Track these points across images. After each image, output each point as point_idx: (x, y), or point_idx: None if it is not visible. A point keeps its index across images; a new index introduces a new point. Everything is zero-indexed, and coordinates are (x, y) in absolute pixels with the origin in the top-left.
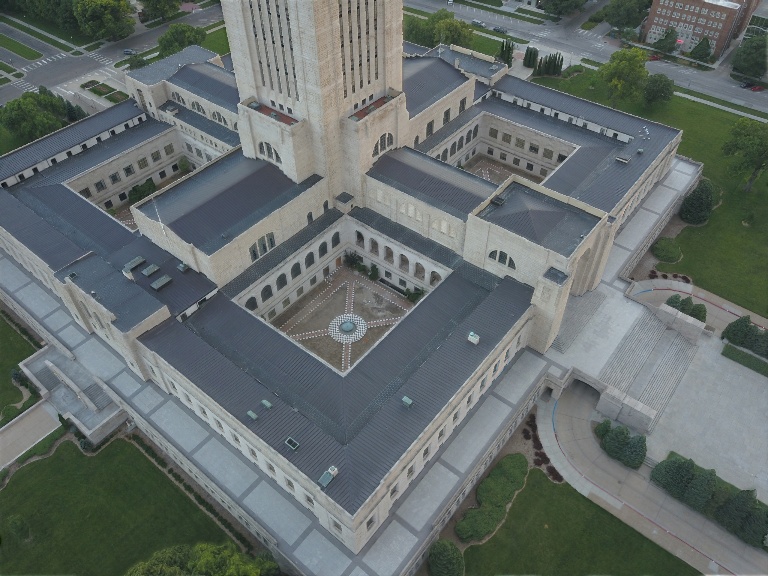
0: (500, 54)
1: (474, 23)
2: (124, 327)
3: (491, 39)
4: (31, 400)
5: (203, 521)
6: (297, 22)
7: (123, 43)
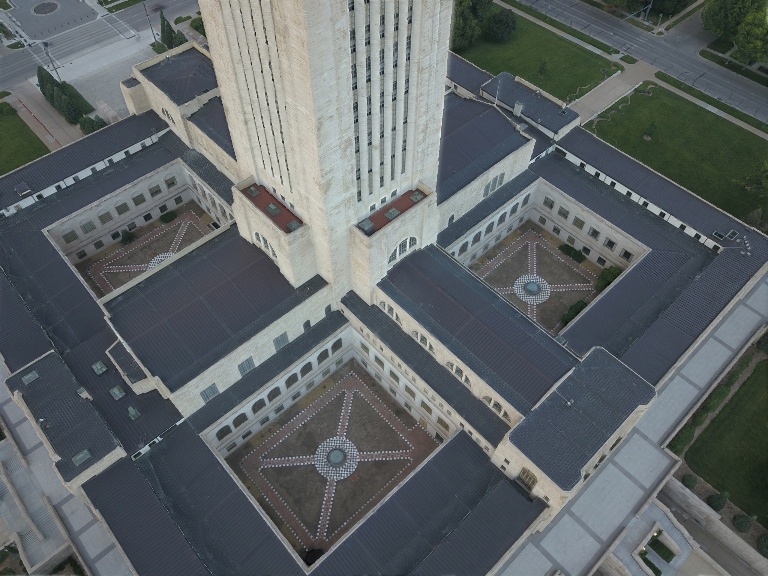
0: None
1: None
2: (506, 75)
3: None
4: None
5: None
6: None
7: None
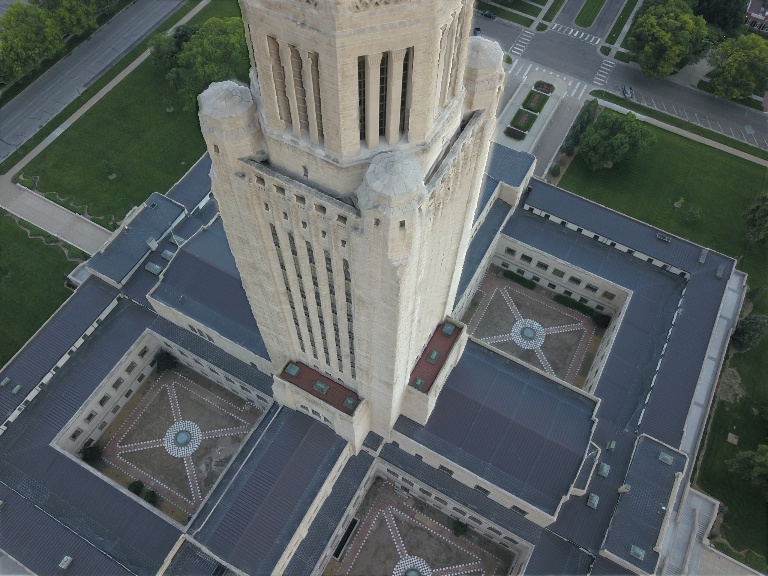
0: None
1: None
2: (93, 262)
3: None
4: None
5: None
6: None
7: (648, 78)
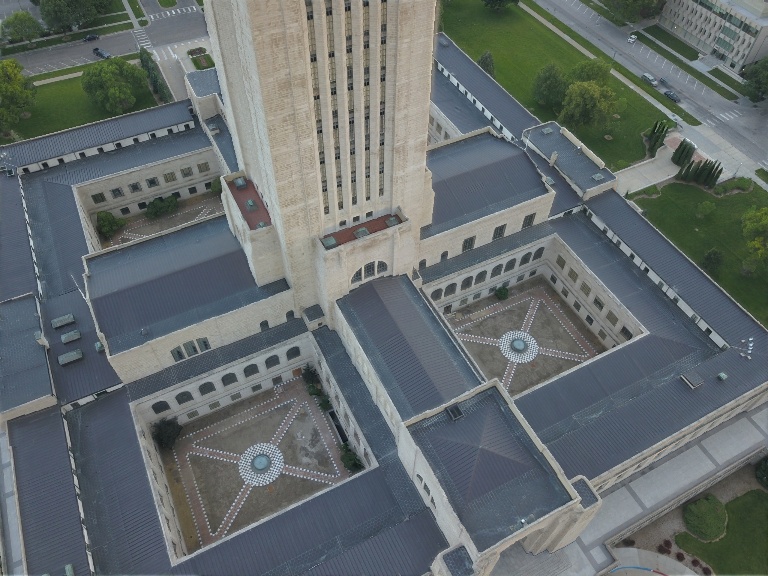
0: (649, 135)
1: (644, 78)
2: None
3: (653, 107)
4: None
5: None
6: (257, 131)
7: None
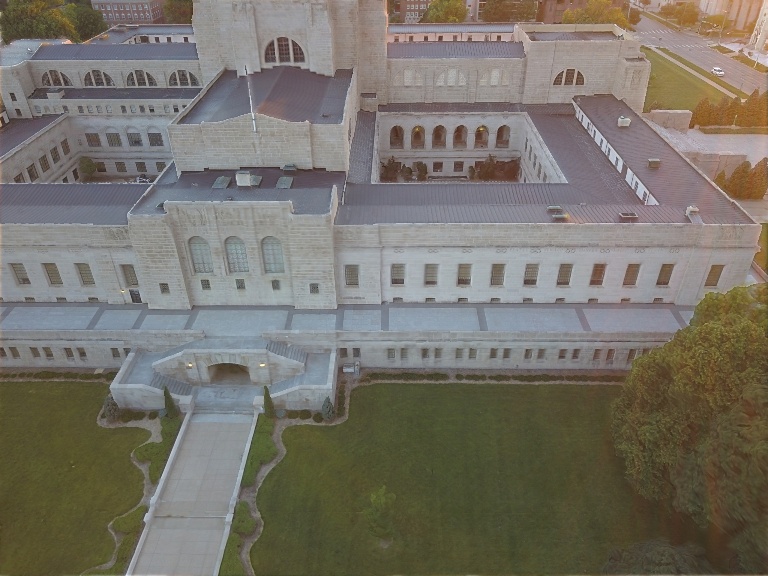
0: None
1: None
2: (317, 211)
3: None
4: (171, 422)
5: (557, 391)
6: None
7: None
